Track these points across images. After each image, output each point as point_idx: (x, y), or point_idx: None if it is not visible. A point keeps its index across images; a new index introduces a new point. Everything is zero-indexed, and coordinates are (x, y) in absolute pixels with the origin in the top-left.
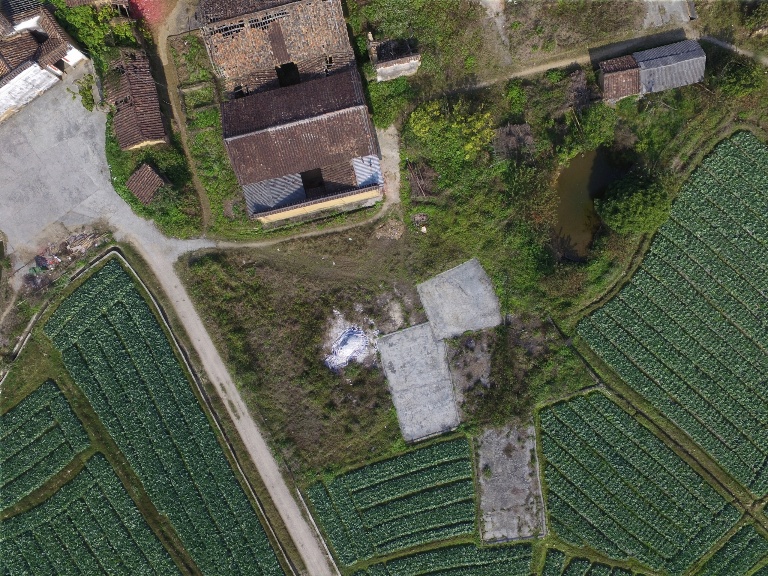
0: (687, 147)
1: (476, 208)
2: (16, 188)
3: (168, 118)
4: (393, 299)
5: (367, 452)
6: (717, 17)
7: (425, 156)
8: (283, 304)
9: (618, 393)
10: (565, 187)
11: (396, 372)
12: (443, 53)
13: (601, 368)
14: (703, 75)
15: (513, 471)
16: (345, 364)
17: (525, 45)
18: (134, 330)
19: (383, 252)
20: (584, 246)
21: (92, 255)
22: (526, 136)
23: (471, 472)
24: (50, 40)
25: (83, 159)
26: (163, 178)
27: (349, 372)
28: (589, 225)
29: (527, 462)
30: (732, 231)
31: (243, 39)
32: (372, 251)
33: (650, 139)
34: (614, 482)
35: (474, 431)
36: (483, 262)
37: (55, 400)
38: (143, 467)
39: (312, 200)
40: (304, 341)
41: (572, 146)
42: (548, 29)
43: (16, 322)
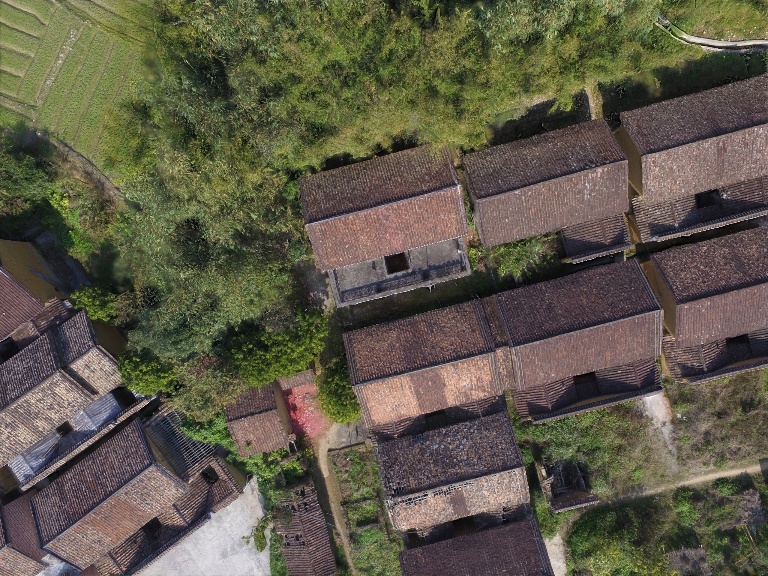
0: None
1: None
2: None
3: (330, 529)
4: None
5: None
6: None
7: None
8: None
9: None
10: None
11: None
12: (611, 469)
13: None
14: None
15: None
16: None
17: (696, 461)
18: None
19: None
20: None
21: None
22: (702, 563)
23: None
24: (221, 482)
25: (248, 575)
26: None
27: None
28: None
29: None
30: None
31: (426, 505)
32: None
33: None
34: None
35: None
36: None
37: None
38: None
39: None
40: None
41: None
42: (719, 445)
43: None
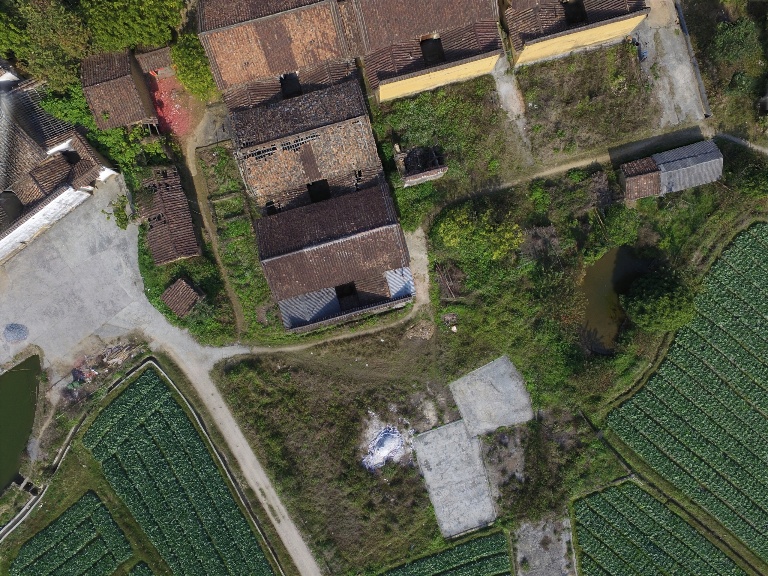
0: (707, 241)
1: (504, 307)
2: (51, 303)
3: (199, 228)
4: (427, 398)
5: (407, 550)
6: (731, 115)
7: (453, 257)
8: (319, 408)
9: (649, 482)
10: (590, 281)
11: (432, 470)
12: (467, 157)
13: (632, 459)
14: (721, 174)
15: (550, 563)
16: (382, 464)
17: (547, 148)
18: (173, 439)
19: (415, 352)
20: (610, 338)
21: (128, 366)
22: (552, 238)
23: (509, 566)
24: (83, 162)
25: (116, 272)
26: (198, 291)
27: (387, 473)
28: (614, 318)
29: (564, 554)
30: (753, 321)
31: (275, 161)
32: (404, 351)
33: (671, 234)
34: (649, 570)
35: (511, 526)
36: (513, 359)
37: (96, 512)
38: (186, 574)
39: (347, 313)
40: (341, 443)
41: (598, 249)
42: (568, 131)
43: (55, 436)
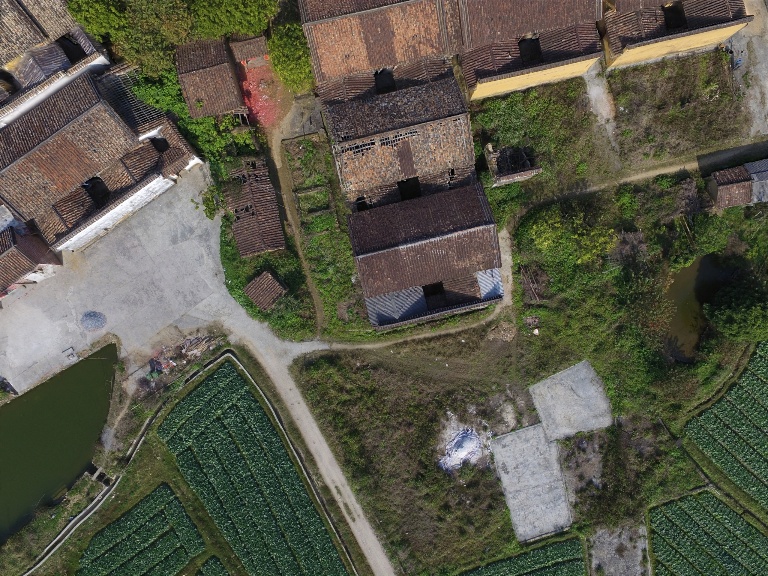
0: None
1: (588, 311)
2: (130, 291)
3: (282, 221)
4: (506, 401)
5: (481, 553)
6: None
7: (538, 260)
8: (398, 406)
9: (726, 492)
10: (672, 289)
11: (509, 473)
12: (556, 160)
13: (710, 468)
14: None
15: (625, 571)
16: (459, 466)
17: (637, 153)
18: (249, 433)
19: (496, 354)
20: (691, 347)
21: (207, 358)
22: (640, 244)
23: (584, 572)
24: (172, 149)
25: (198, 262)
26: (283, 285)
27: (465, 475)
28: (696, 326)
29: (639, 562)
30: None
31: (373, 156)
32: (485, 353)
33: (756, 244)
34: None
35: (588, 532)
36: (594, 364)
37: (170, 505)
38: (259, 571)
39: (437, 312)
40: (419, 443)
41: (688, 256)
42: (659, 137)
43: (131, 427)
